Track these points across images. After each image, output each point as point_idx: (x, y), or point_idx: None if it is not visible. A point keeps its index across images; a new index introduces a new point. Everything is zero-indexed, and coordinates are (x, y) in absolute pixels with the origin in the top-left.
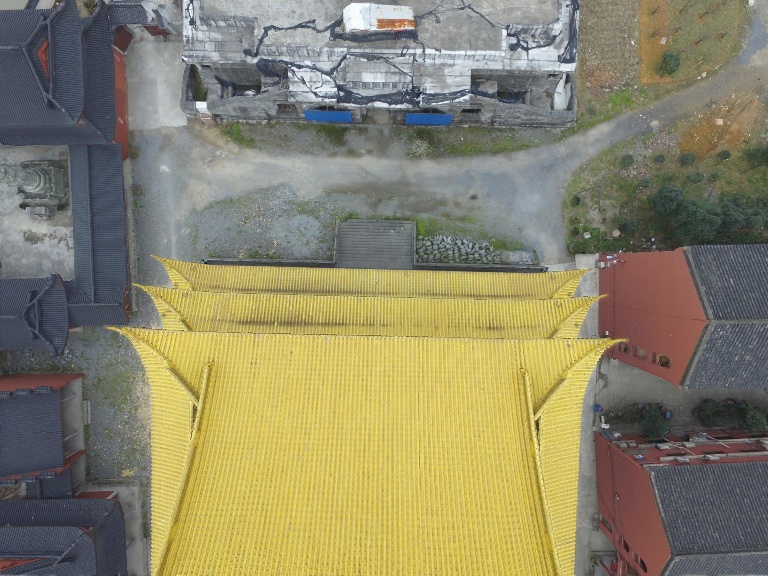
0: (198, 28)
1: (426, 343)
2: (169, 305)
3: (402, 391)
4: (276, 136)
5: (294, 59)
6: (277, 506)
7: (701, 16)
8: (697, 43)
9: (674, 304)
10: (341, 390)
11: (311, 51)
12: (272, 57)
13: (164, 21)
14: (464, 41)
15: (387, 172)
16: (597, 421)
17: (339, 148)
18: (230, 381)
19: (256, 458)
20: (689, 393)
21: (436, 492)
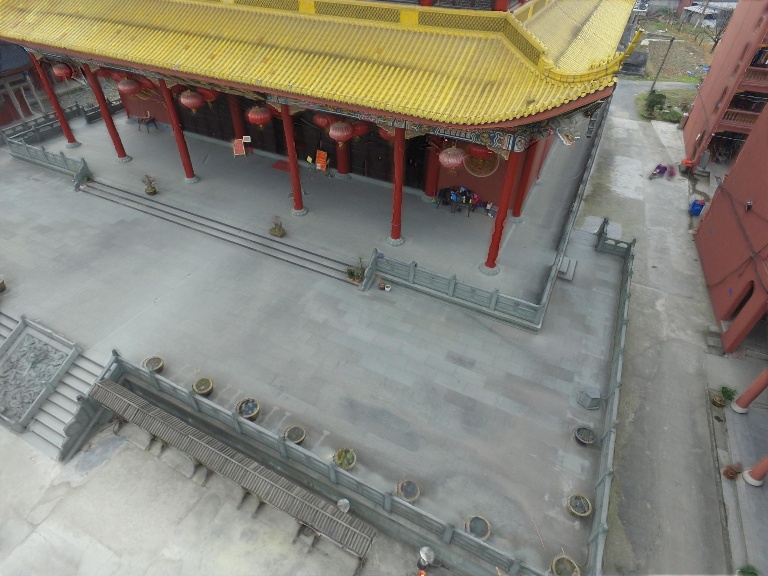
0: None
1: None
2: None
3: None
4: None
5: None
6: None
7: None
8: None
9: None
10: None
11: None
12: None
13: None
14: None
15: None
16: (696, 227)
17: None
18: None
19: None
20: None
21: None
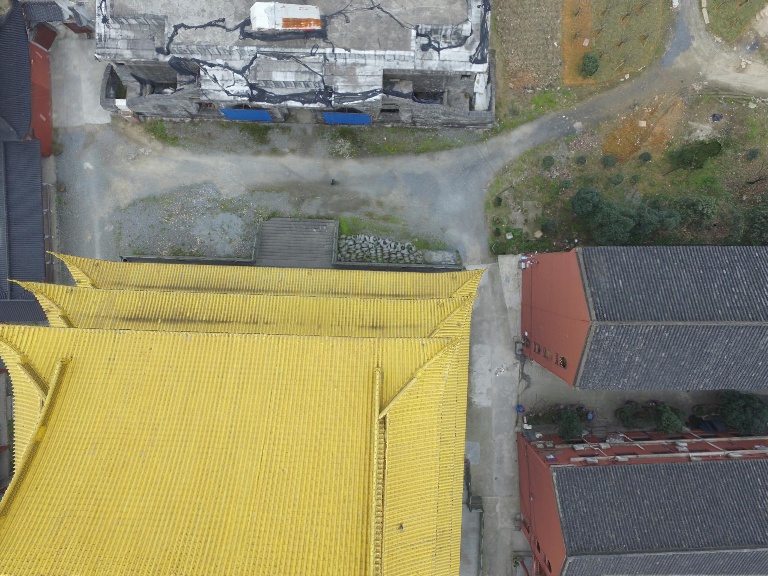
0: (111, 26)
1: (286, 341)
2: (50, 301)
3: (256, 388)
4: (199, 134)
5: (206, 57)
6: (110, 501)
7: (623, 18)
8: (619, 45)
9: (569, 305)
10: (195, 387)
11: (221, 50)
12: (184, 55)
13: (82, 19)
14: (373, 41)
15: (310, 171)
16: (520, 421)
17: (262, 147)
18: (86, 377)
19: (99, 453)
20: (612, 394)
21: (272, 489)
